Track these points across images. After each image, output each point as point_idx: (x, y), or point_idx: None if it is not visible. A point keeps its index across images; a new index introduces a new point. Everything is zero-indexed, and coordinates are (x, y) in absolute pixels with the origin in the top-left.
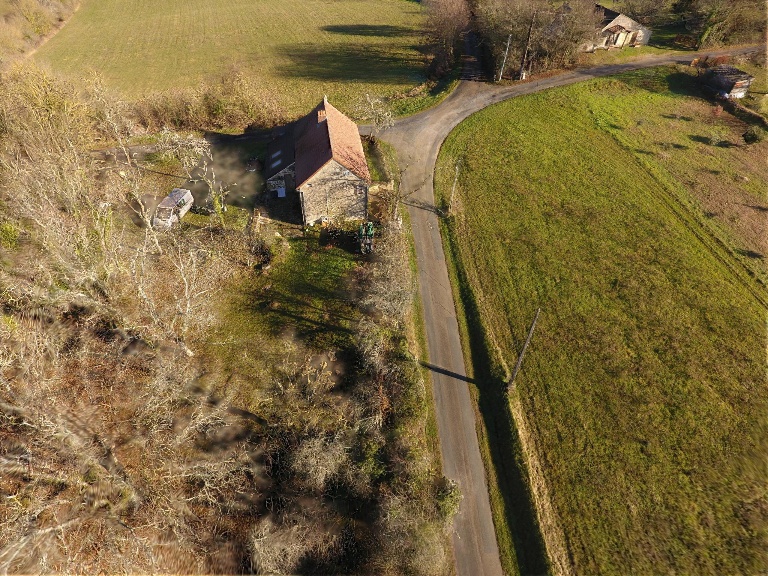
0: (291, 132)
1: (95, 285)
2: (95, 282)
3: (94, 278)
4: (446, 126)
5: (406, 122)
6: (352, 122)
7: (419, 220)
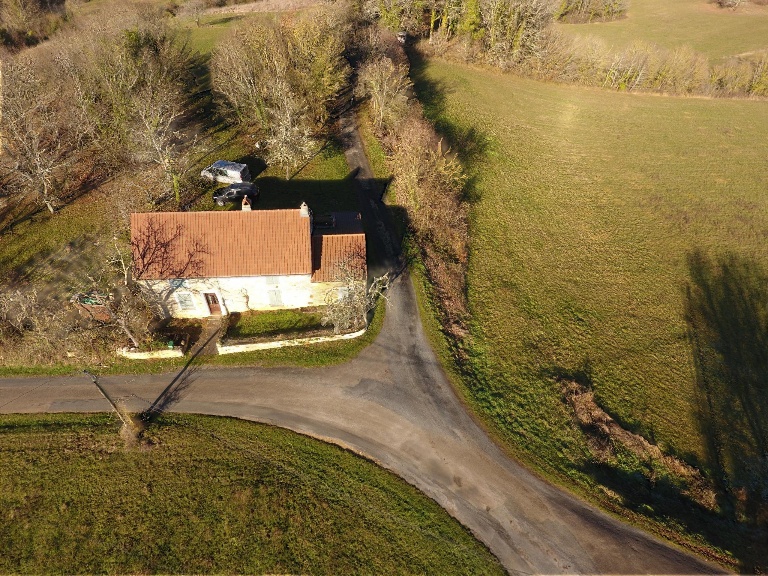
0: (320, 219)
1: (7, 109)
2: (7, 107)
3: (5, 104)
4: (423, 470)
5: (434, 390)
6: (307, 264)
7: (141, 385)
